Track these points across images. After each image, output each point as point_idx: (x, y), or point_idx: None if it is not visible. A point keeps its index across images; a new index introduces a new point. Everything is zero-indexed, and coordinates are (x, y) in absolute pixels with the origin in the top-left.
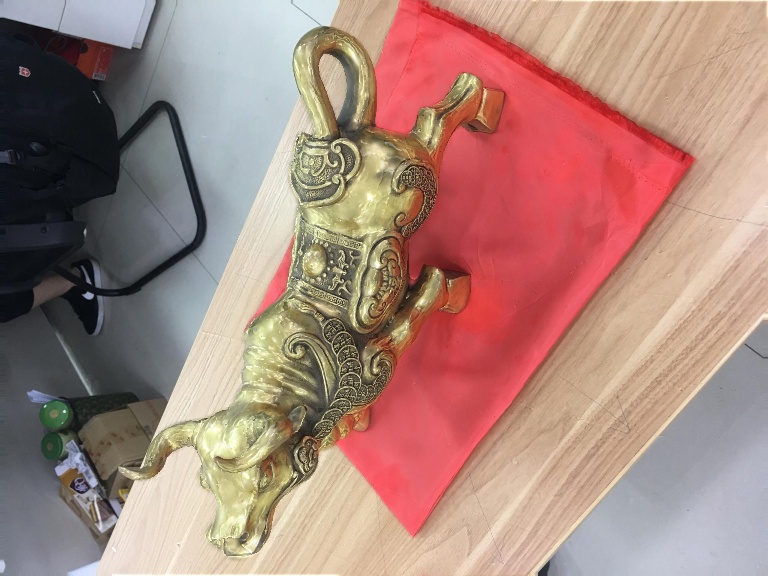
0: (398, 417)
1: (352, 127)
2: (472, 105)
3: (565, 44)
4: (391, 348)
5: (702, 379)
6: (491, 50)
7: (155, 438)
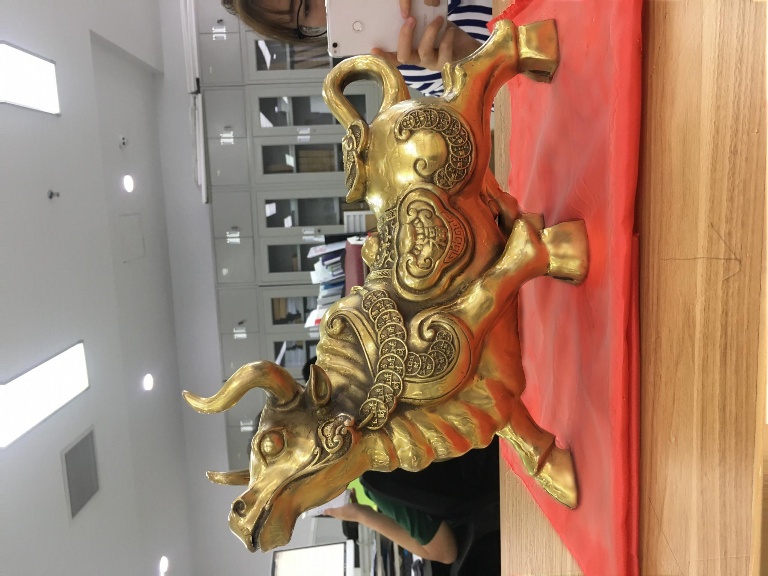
0: (591, 461)
1: None
2: (503, 44)
3: None
4: (453, 311)
5: (767, 85)
6: None
7: None
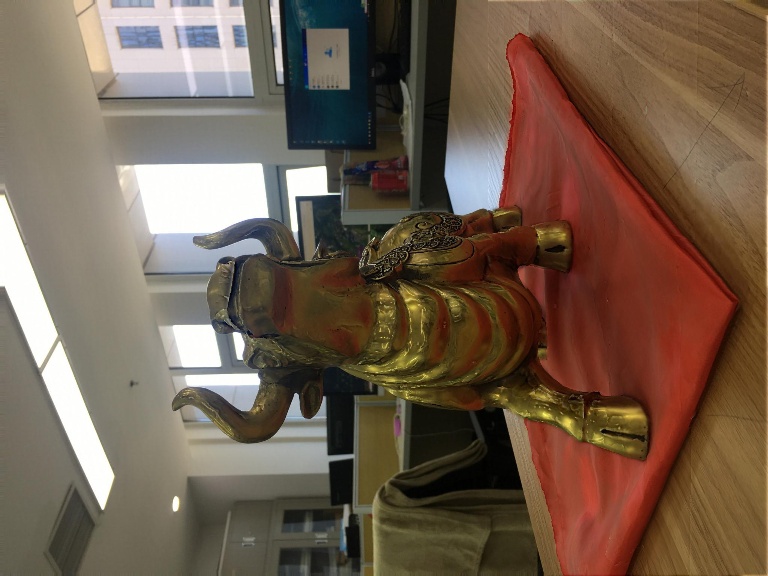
0: (633, 338)
1: None
2: None
3: None
4: None
5: None
6: None
7: None
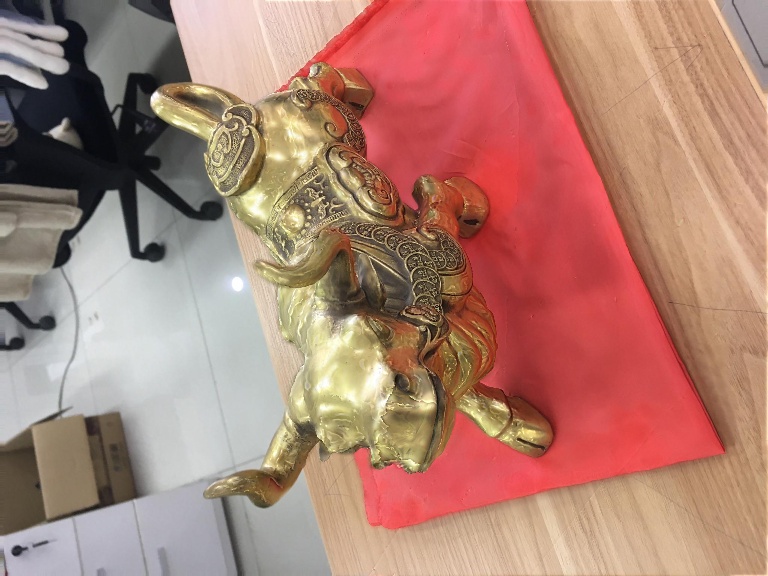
0: (559, 370)
1: None
2: (331, 74)
3: (356, 1)
4: None
5: None
6: None
7: None
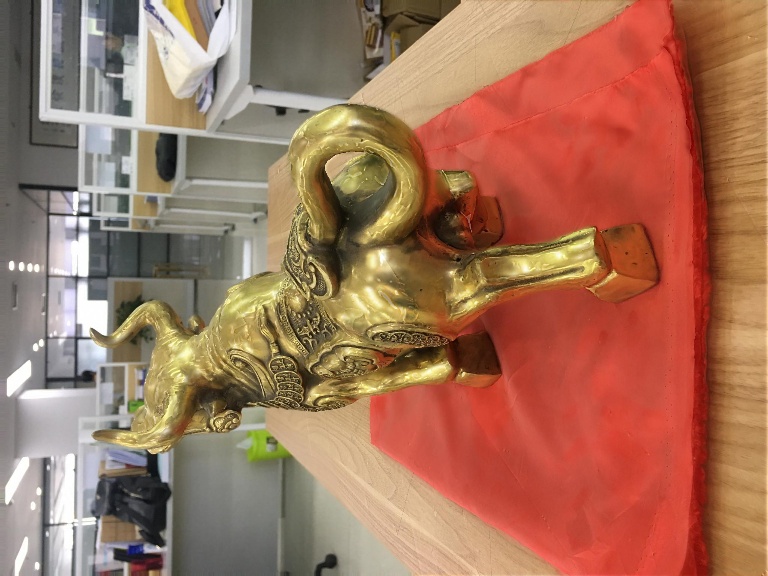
0: None
1: (359, 239)
2: (571, 285)
3: (761, 341)
4: (350, 395)
5: None
6: (692, 213)
7: (142, 306)
